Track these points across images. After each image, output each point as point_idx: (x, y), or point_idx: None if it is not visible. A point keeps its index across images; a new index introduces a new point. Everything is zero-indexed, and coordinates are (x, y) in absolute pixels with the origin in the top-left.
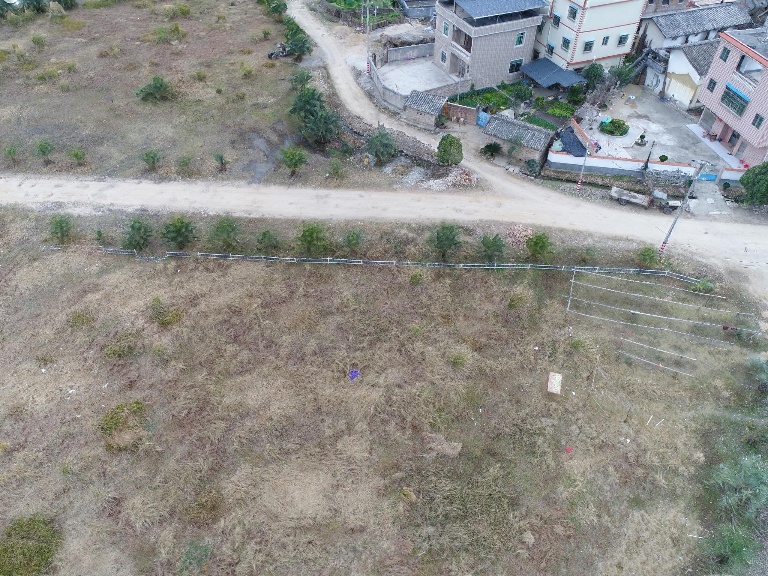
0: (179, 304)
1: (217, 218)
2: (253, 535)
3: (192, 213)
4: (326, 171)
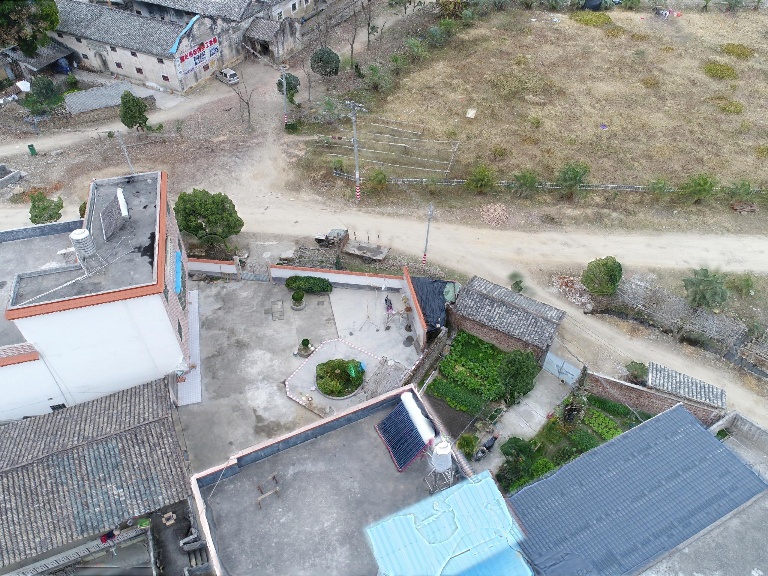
0: None
1: None
2: None
3: None
4: (759, 298)
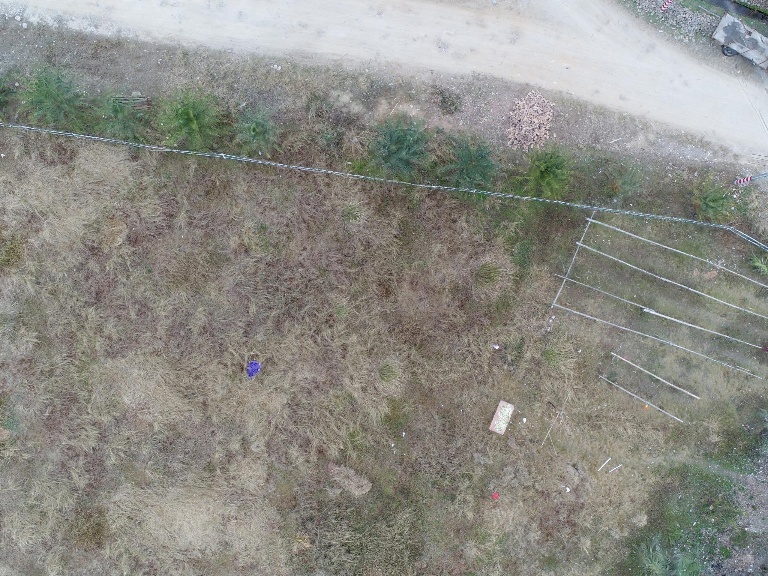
0: (13, 226)
1: (44, 33)
2: (141, 563)
3: (1, 18)
4: None
